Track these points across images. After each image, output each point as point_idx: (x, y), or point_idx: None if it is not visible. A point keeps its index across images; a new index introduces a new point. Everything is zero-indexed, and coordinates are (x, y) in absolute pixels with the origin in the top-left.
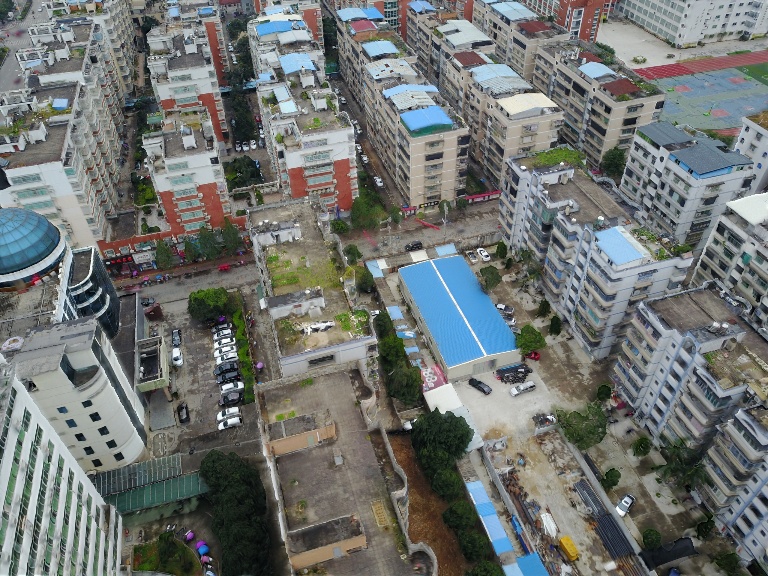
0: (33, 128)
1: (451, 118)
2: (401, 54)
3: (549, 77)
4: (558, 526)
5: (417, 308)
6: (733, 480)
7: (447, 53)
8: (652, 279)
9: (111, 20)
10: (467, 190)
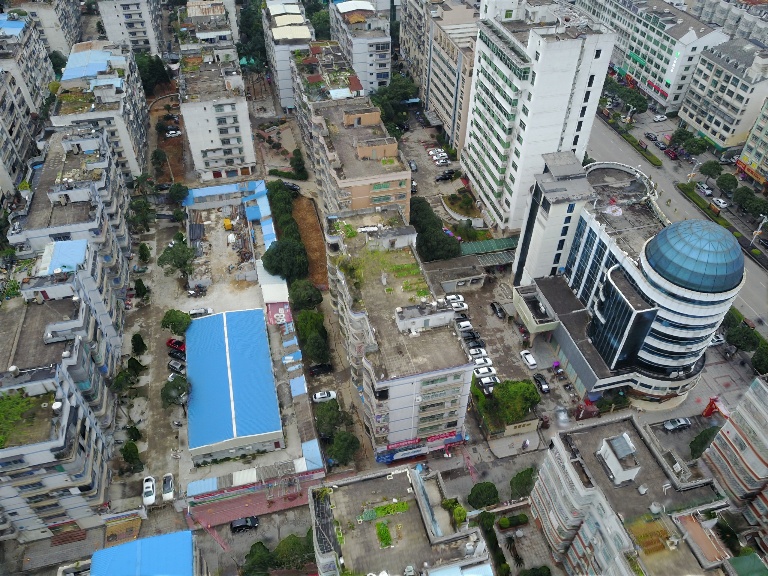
0: None
1: None
2: None
3: None
4: (227, 238)
5: None
6: None
7: None
8: None
9: None
10: None
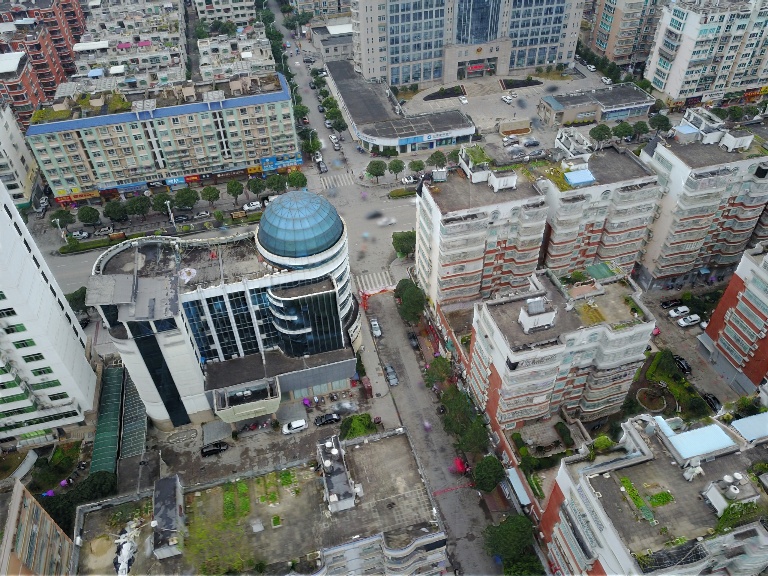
0: (500, 173)
1: None
2: None
3: None
4: None
5: None
6: None
7: None
8: None
9: None
10: None
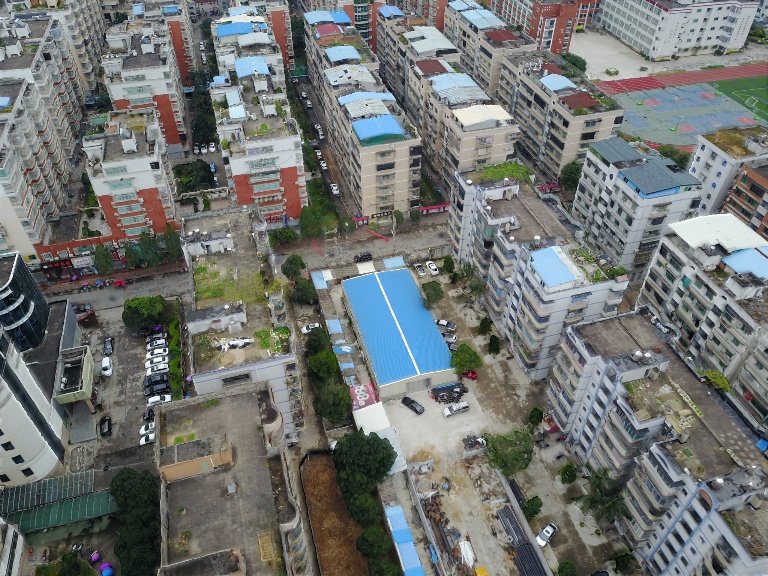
0: None
1: (405, 128)
2: (364, 60)
3: (513, 88)
4: (476, 555)
5: (356, 322)
6: (649, 514)
7: (411, 60)
8: (586, 302)
9: (72, 16)
10: (423, 201)
